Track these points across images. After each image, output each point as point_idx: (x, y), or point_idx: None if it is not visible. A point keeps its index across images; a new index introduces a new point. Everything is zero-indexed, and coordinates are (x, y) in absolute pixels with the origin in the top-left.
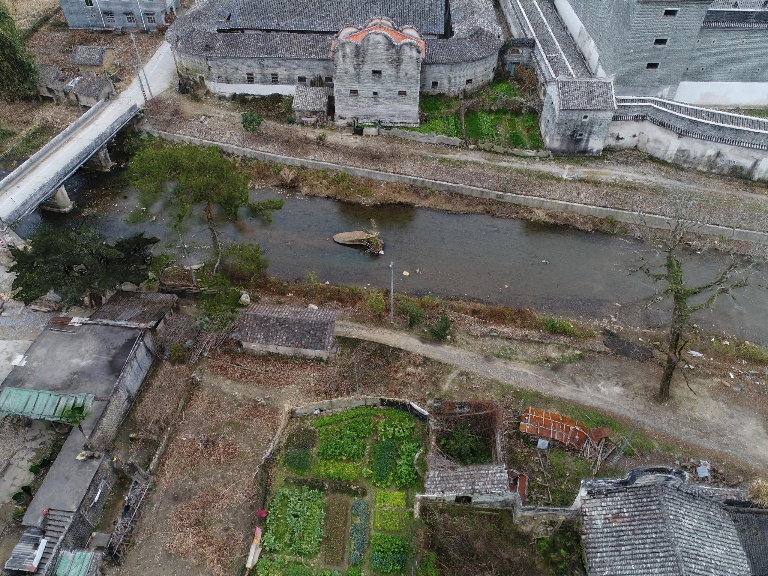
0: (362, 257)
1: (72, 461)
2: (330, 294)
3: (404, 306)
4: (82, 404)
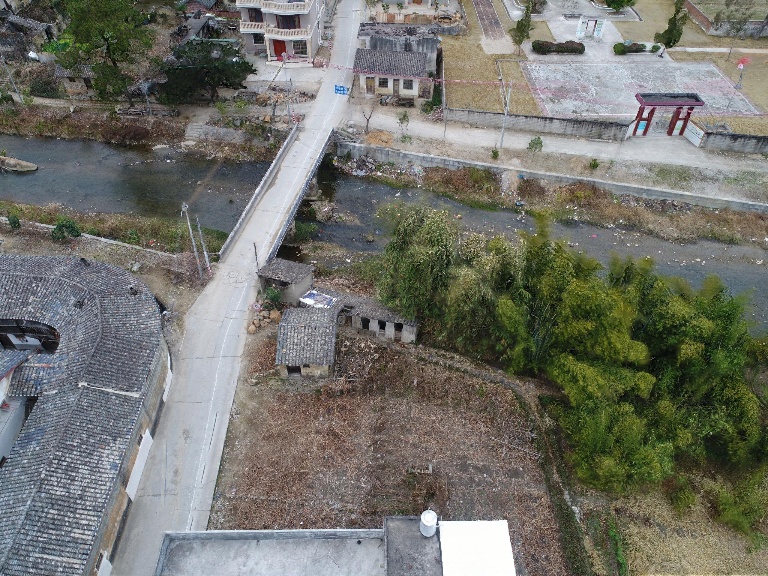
0: (21, 159)
1: (194, 26)
2: (59, 121)
3: (10, 109)
4: (196, 38)
